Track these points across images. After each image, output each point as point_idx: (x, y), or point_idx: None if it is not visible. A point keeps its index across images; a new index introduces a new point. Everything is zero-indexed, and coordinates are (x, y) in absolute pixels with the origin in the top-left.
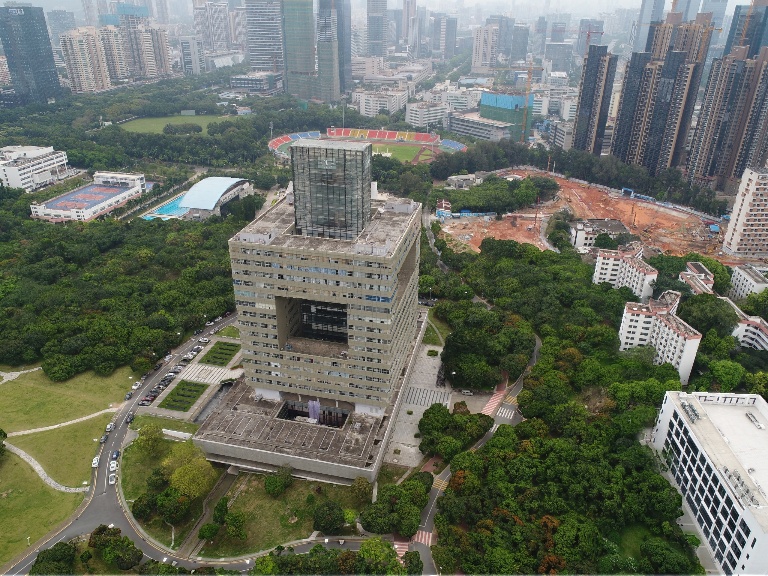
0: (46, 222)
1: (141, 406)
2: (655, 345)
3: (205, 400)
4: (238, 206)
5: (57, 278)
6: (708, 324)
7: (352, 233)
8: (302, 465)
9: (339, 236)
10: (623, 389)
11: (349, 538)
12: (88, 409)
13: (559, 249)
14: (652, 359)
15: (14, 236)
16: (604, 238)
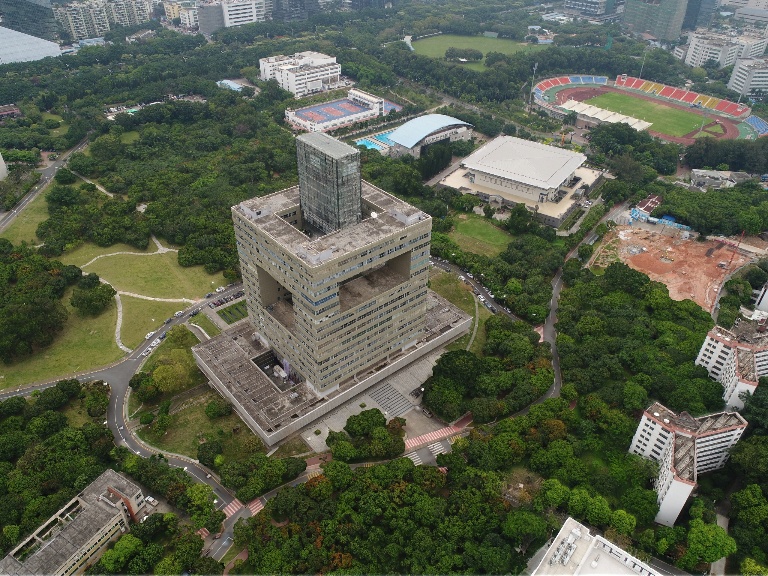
0: (291, 127)
1: (209, 307)
2: (662, 465)
3: None
4: None
5: (247, 181)
6: (763, 476)
7: (332, 230)
8: (237, 405)
9: (325, 229)
10: (556, 490)
11: (215, 476)
12: (179, 294)
13: (720, 303)
14: (647, 478)
15: (257, 135)
16: None
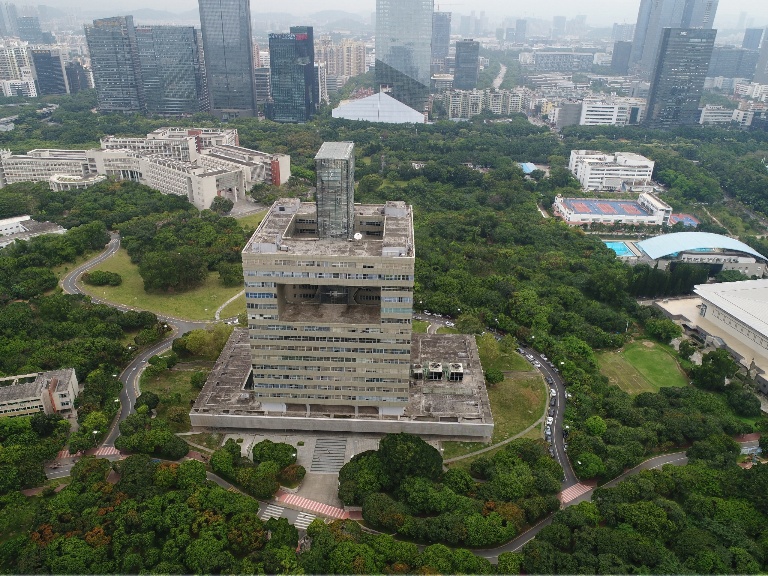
0: (554, 213)
1: None
2: None
3: None
4: None
5: None
6: None
7: None
8: None
9: None
10: None
11: None
12: None
13: None
14: None
15: None
16: None
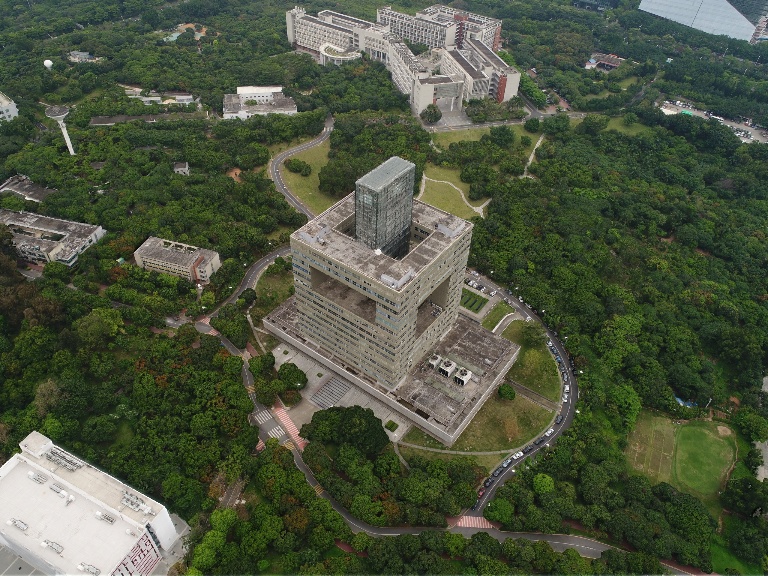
0: None
1: None
2: None
3: None
4: None
5: None
6: None
7: None
8: None
9: None
10: (217, 515)
11: None
12: None
13: None
14: None
15: None
16: None
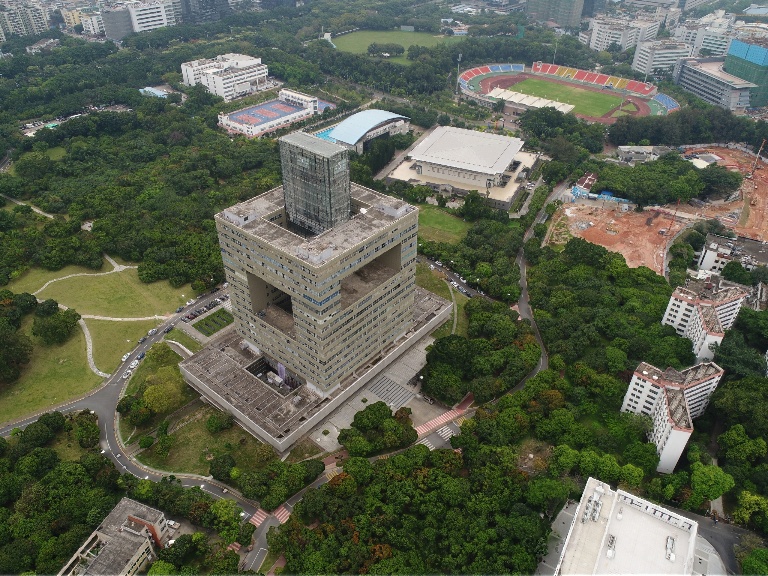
0: (226, 131)
1: (182, 321)
2: (655, 419)
3: (227, 331)
4: (378, 145)
5: (194, 190)
6: (743, 416)
7: (324, 229)
8: (239, 416)
9: (315, 229)
10: (567, 455)
11: (232, 490)
12: (148, 312)
13: (669, 267)
14: (644, 433)
15: (193, 142)
16: (732, 268)
